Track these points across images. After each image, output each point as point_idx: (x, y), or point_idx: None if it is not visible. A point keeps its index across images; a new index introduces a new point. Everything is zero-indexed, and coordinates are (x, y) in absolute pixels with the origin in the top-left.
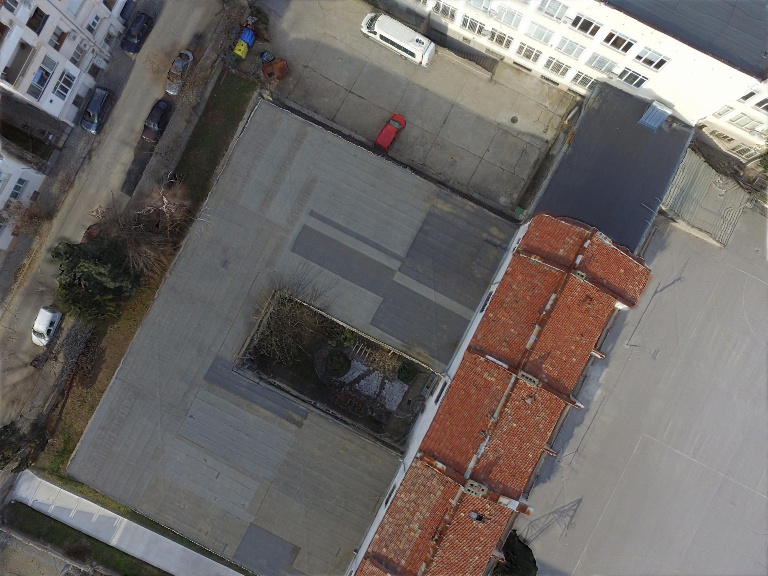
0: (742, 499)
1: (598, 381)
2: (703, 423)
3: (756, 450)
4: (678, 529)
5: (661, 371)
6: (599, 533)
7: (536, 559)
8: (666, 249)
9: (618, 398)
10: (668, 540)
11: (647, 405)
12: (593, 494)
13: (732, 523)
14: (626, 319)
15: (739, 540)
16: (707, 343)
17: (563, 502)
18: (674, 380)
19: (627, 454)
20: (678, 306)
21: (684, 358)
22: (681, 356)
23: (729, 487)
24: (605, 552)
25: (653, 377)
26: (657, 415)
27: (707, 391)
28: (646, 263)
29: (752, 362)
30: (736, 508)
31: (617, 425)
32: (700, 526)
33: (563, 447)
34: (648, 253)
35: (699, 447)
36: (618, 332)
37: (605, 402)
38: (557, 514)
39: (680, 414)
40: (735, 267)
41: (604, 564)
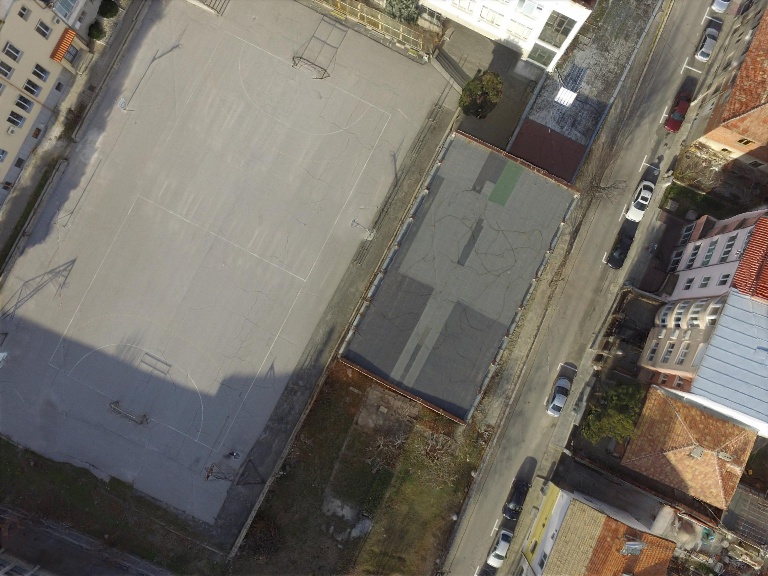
0: (234, 258)
1: (95, 145)
2: (197, 185)
3: (248, 211)
4: (169, 287)
5: (157, 135)
6: (92, 293)
7: (30, 319)
8: (165, 17)
9: (115, 161)
10: (159, 298)
11: (143, 168)
12: (88, 255)
13: (223, 281)
14: (124, 85)
15: (229, 298)
16: (203, 108)
17: (58, 263)
18: (170, 144)
19: (122, 215)
20: (176, 72)
21: (180, 122)
22: (177, 120)
23: (221, 246)
24: (97, 311)
25: (150, 141)
26: (152, 177)
27: (202, 154)
28: (145, 31)
29: (247, 126)
30: (227, 267)
31: (113, 187)
32: (191, 284)
33: (59, 209)
34: (147, 21)
35: (192, 208)
36: (116, 97)
37: (102, 165)
38: (52, 274)
39: (175, 176)
40: (233, 34)
41: (96, 323)
